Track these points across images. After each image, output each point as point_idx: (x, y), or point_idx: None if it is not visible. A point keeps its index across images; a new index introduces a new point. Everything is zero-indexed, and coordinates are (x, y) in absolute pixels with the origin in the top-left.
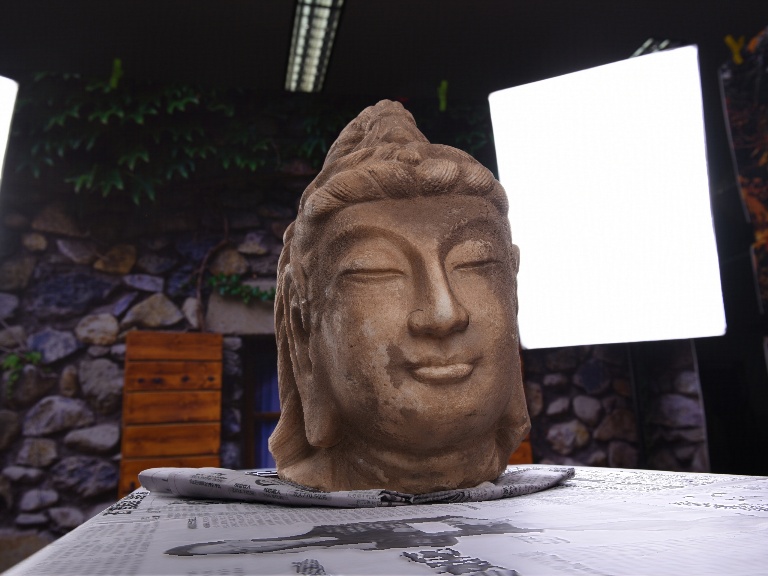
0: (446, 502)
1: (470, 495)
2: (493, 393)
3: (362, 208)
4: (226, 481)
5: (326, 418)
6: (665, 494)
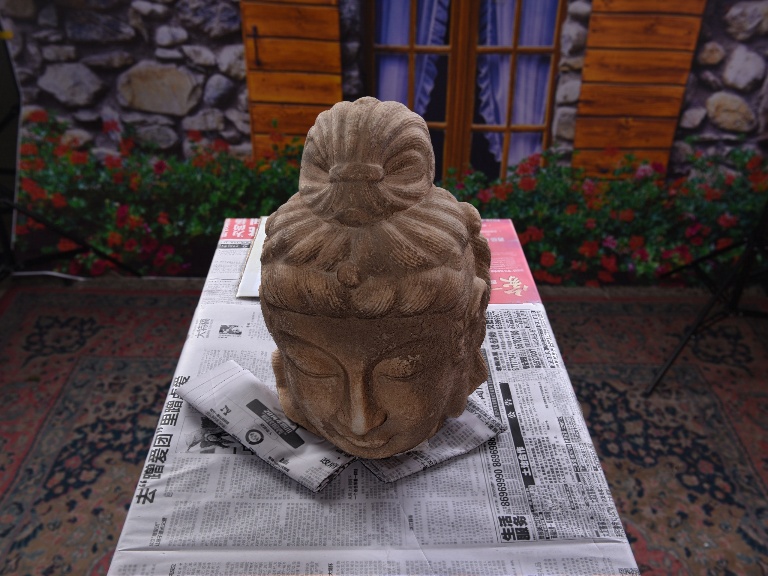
0: (376, 475)
1: None
2: (409, 445)
3: (301, 320)
4: (227, 428)
5: None
6: None
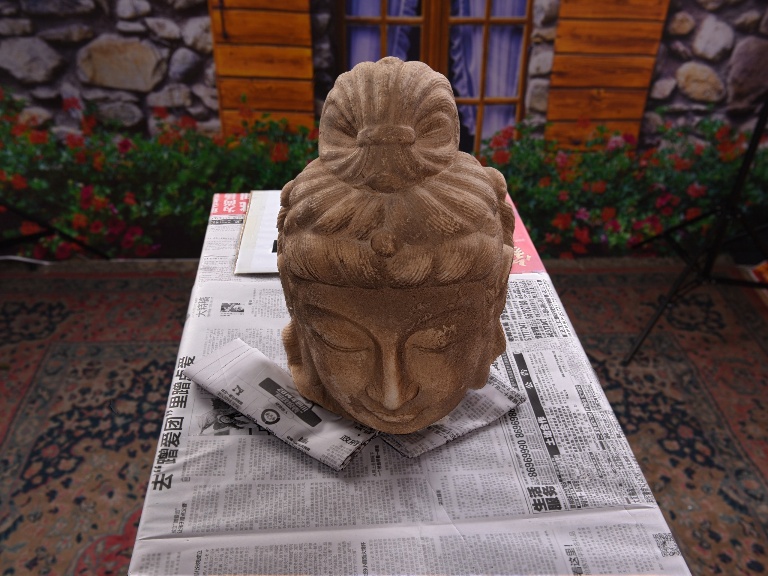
0: (398, 451)
1: (413, 457)
2: None
3: (331, 292)
4: (241, 409)
5: (315, 377)
6: (505, 575)
